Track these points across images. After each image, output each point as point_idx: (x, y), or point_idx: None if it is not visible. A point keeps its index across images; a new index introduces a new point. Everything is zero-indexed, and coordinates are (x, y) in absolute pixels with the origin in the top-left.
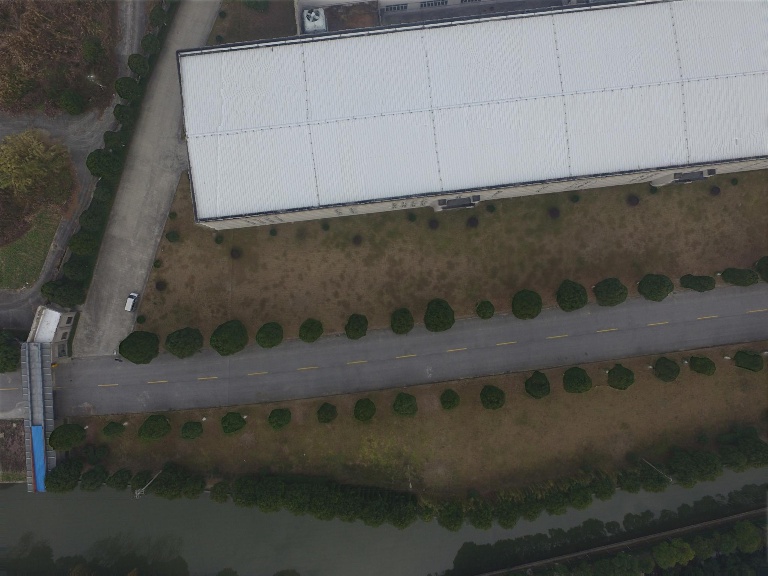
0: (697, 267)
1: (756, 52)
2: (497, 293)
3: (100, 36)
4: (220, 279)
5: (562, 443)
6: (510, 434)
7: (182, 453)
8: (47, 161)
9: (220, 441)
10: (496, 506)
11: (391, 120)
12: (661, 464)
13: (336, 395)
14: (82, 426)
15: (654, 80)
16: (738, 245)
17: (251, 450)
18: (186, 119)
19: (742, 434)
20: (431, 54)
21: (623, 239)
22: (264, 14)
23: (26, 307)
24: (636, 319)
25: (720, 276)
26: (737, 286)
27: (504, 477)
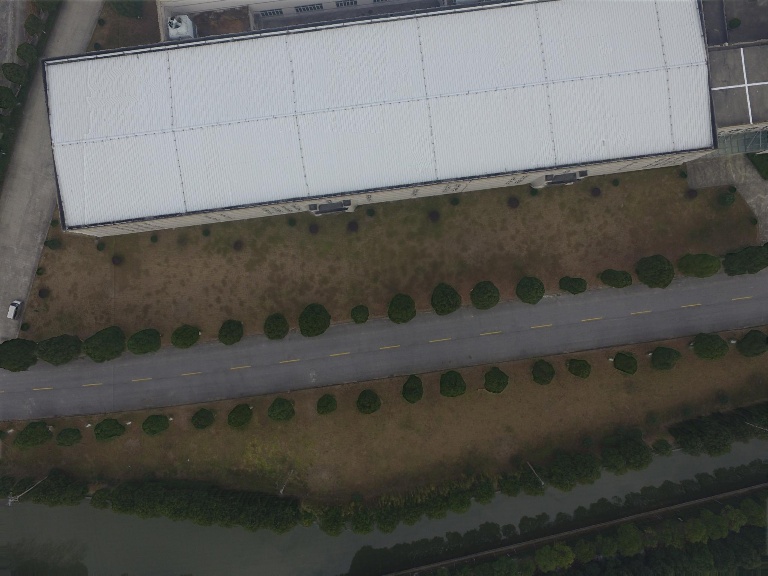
0: (580, 269)
1: (622, 52)
2: (379, 297)
3: None
4: (103, 286)
5: (446, 447)
6: (394, 438)
7: (68, 459)
8: None
9: (105, 447)
10: (376, 510)
11: (255, 126)
12: (542, 467)
13: (220, 400)
14: None
15: (519, 82)
16: (621, 246)
17: (136, 456)
18: (52, 127)
19: (625, 436)
20: (296, 59)
21: (505, 241)
22: (143, 21)
23: None
24: (520, 322)
25: (600, 278)
26: (617, 288)
27: (388, 481)
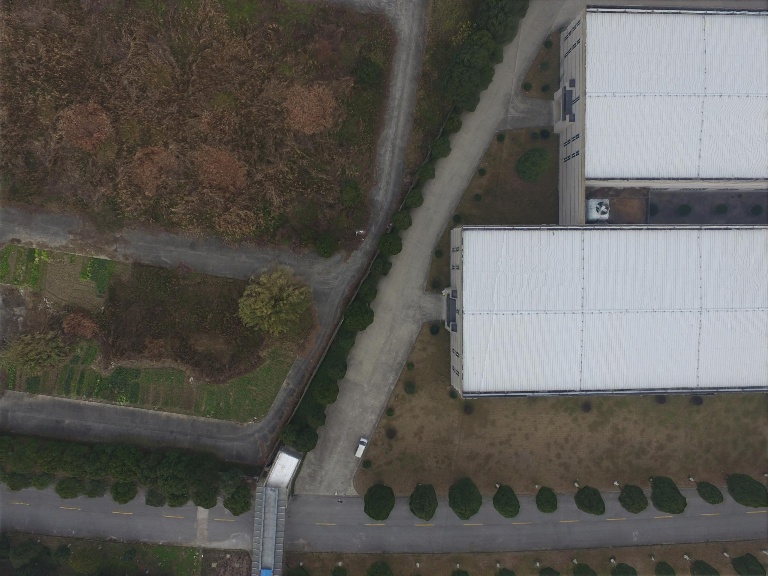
0: None
1: None
2: (708, 467)
3: (356, 178)
4: (449, 431)
5: None
6: None
7: None
8: (294, 303)
9: None
10: None
11: (661, 317)
12: None
13: (545, 550)
14: (299, 564)
15: None
16: None
17: None
18: (464, 295)
19: None
20: (705, 255)
21: None
22: None
23: (252, 441)
24: None
25: None
26: None
27: None
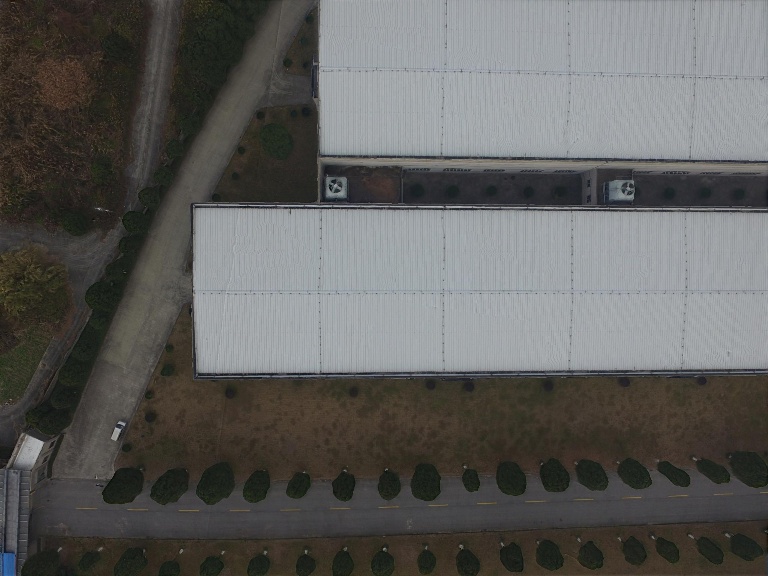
0: (675, 449)
1: (759, 271)
2: (484, 455)
3: (111, 155)
4: (212, 416)
5: None
6: None
7: None
8: (43, 282)
9: (195, 573)
10: None
11: (402, 298)
12: None
13: (316, 538)
14: (56, 548)
15: (660, 288)
16: (715, 432)
17: None
18: (194, 274)
19: None
20: (449, 236)
21: (610, 416)
22: None
23: (7, 423)
24: (612, 492)
25: (695, 464)
26: None
27: None
